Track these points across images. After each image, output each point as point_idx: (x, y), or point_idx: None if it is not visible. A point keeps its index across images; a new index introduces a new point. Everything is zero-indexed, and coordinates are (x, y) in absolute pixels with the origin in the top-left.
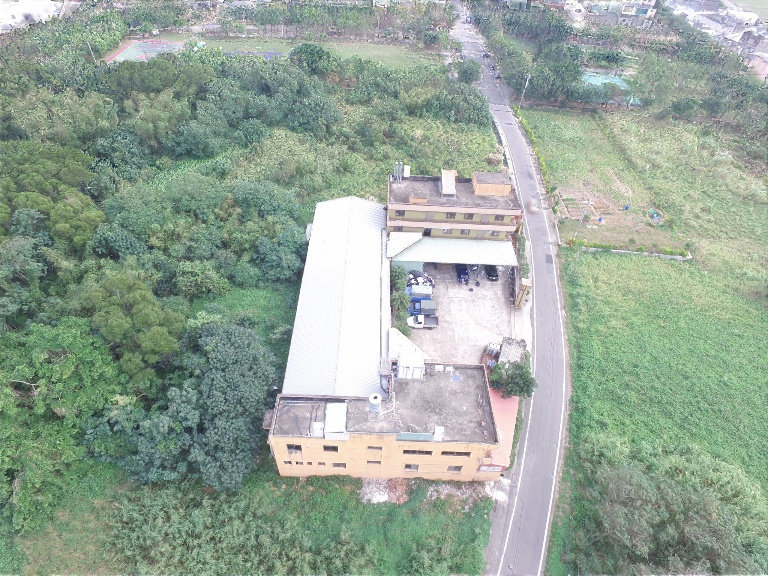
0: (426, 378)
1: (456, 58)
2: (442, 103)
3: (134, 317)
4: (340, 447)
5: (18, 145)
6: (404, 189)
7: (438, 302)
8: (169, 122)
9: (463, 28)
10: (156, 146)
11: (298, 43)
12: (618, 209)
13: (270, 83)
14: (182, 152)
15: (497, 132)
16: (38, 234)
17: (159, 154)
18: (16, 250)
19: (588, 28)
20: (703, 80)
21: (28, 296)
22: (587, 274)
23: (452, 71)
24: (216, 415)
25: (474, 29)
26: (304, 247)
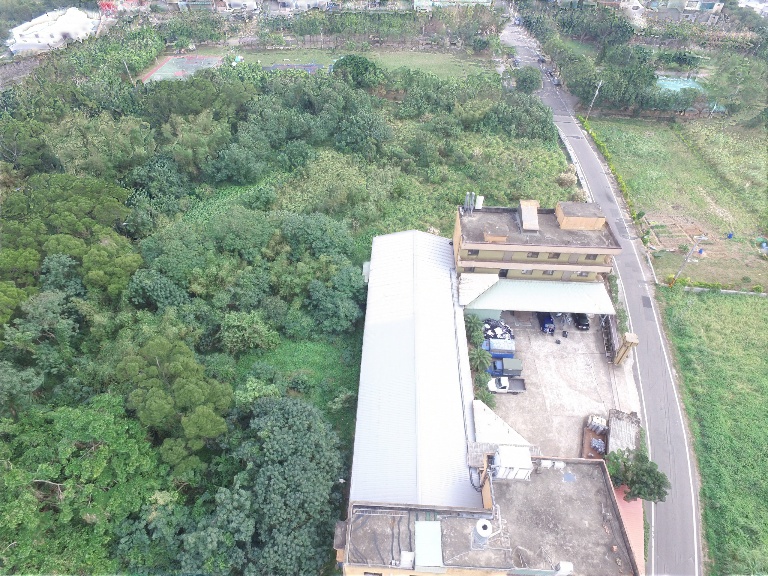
0: (531, 477)
1: (509, 64)
2: (501, 116)
3: (176, 394)
4: None
5: (50, 179)
6: (476, 223)
7: (521, 358)
8: (209, 146)
9: (512, 31)
10: (195, 173)
11: (339, 54)
12: (719, 237)
13: (314, 99)
14: (222, 179)
15: (564, 147)
16: (69, 282)
17: (198, 181)
18: (44, 307)
19: (648, 26)
20: None
21: (57, 357)
22: (696, 321)
23: (508, 79)
24: (275, 525)
25: (524, 32)
26: (362, 291)
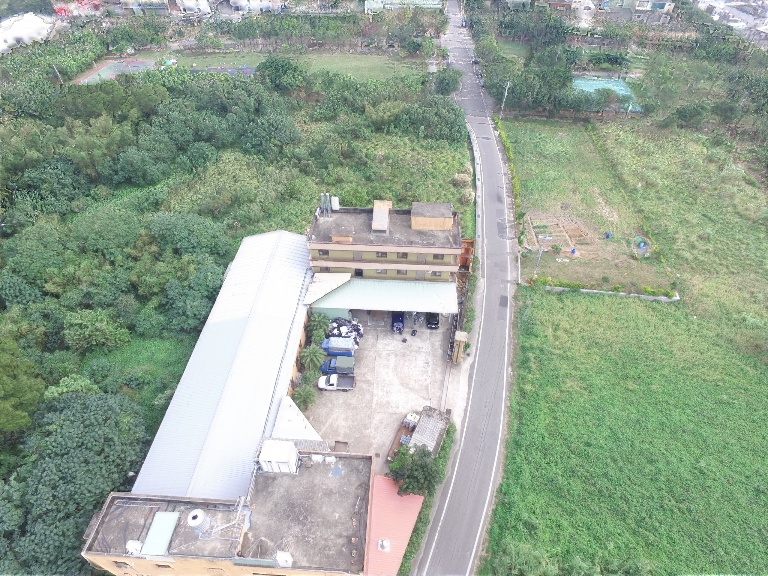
0: (299, 471)
1: (442, 66)
2: (412, 117)
3: None
4: (172, 566)
5: None
6: None
7: (362, 356)
8: (108, 149)
9: (457, 33)
10: (93, 175)
11: (276, 56)
12: (598, 237)
13: (226, 102)
14: (120, 180)
15: (471, 148)
16: None
17: (100, 182)
18: None
19: (596, 27)
20: (719, 81)
21: None
22: (546, 321)
23: (430, 81)
24: (41, 515)
25: (468, 33)
26: (218, 290)
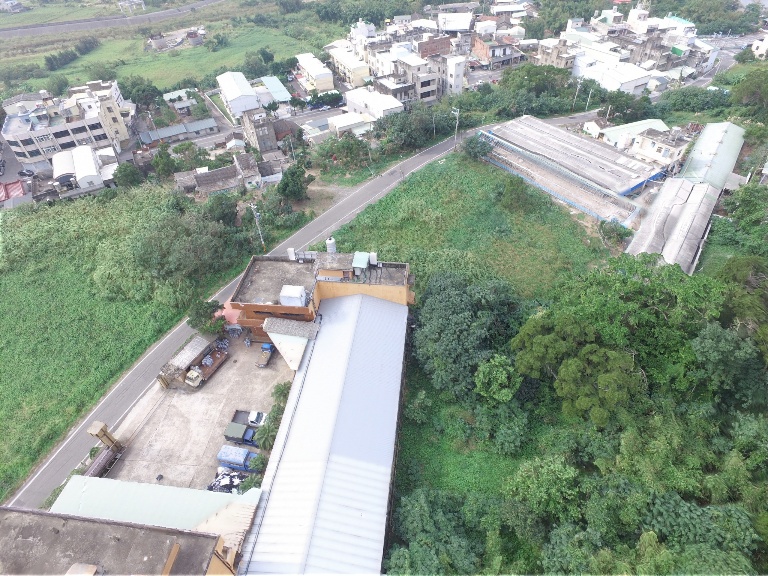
0: None
1: None
2: None
3: (558, 336)
4: None
5: None
6: None
7: None
8: None
9: None
10: None
11: None
12: None
13: None
14: None
15: None
16: None
17: None
18: None
19: None
20: None
21: None
22: None
23: None
24: None
25: None
26: (394, 551)
